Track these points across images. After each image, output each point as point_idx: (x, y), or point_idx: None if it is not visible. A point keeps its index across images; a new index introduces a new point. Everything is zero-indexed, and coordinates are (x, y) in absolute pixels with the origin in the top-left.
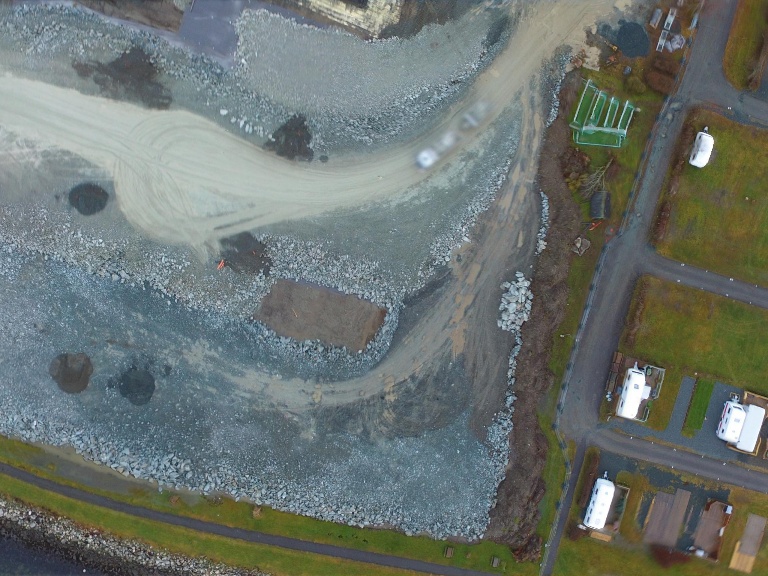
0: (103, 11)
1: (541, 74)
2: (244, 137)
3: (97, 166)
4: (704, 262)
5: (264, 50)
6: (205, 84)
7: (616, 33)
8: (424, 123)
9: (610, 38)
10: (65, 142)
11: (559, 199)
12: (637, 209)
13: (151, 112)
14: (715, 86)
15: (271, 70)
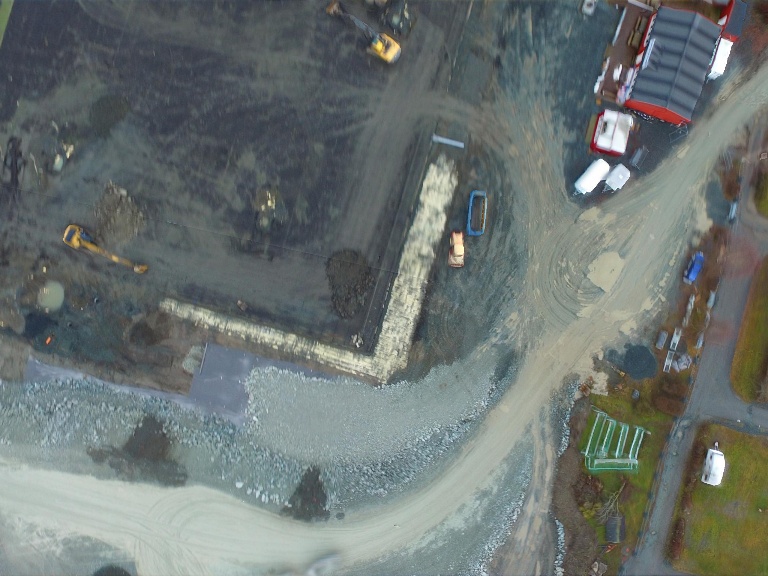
0: (113, 380)
1: (550, 405)
2: (261, 506)
3: (117, 548)
4: (720, 573)
5: (275, 406)
6: (219, 449)
7: (623, 357)
8: (437, 466)
9: (617, 363)
10: (85, 528)
11: (574, 528)
12: (652, 527)
13: (167, 491)
14: (723, 400)
15: (283, 425)
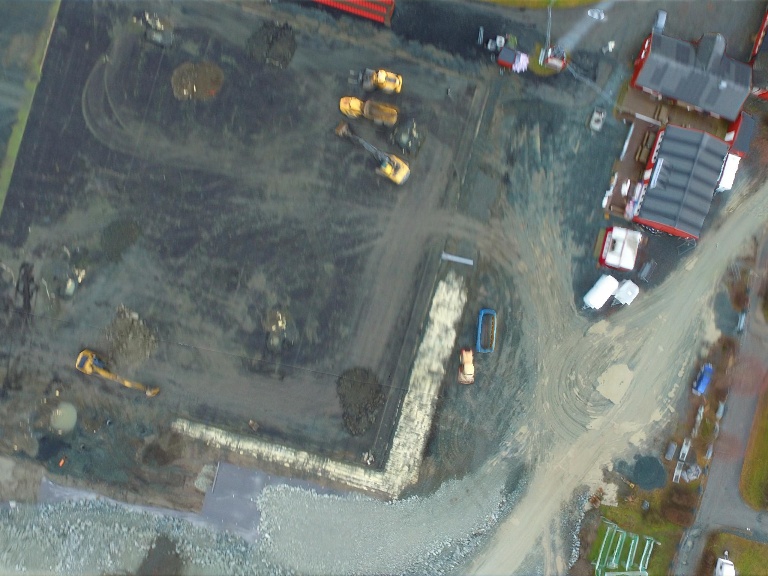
0: (126, 500)
1: (560, 517)
2: None
3: None
4: None
5: (287, 523)
6: (231, 568)
7: (632, 468)
8: None
9: (627, 474)
10: None
11: None
12: None
13: None
14: (733, 509)
15: (295, 541)
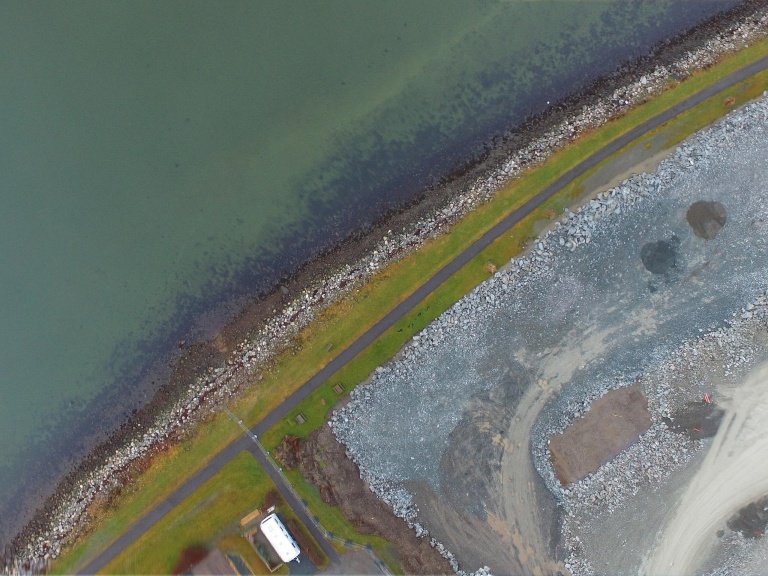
0: None
1: None
2: None
3: None
4: None
5: None
6: None
7: None
8: None
9: None
10: None
11: None
12: None
13: None
14: None
15: None
